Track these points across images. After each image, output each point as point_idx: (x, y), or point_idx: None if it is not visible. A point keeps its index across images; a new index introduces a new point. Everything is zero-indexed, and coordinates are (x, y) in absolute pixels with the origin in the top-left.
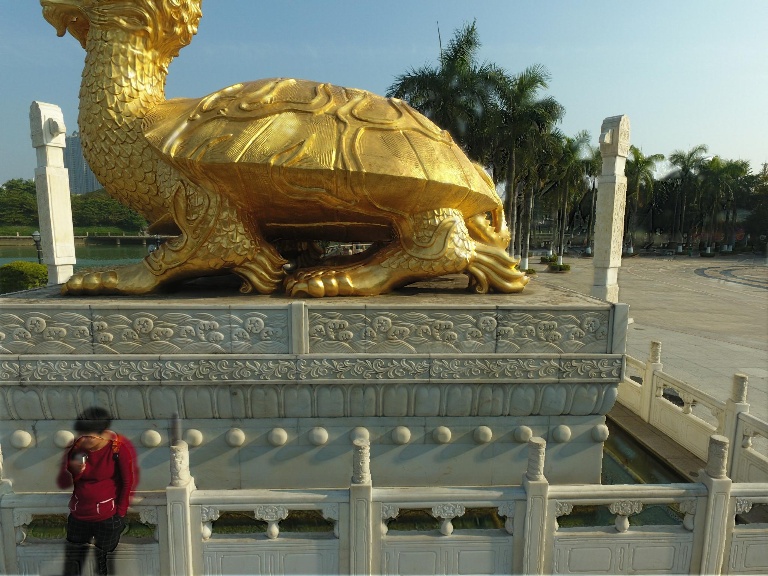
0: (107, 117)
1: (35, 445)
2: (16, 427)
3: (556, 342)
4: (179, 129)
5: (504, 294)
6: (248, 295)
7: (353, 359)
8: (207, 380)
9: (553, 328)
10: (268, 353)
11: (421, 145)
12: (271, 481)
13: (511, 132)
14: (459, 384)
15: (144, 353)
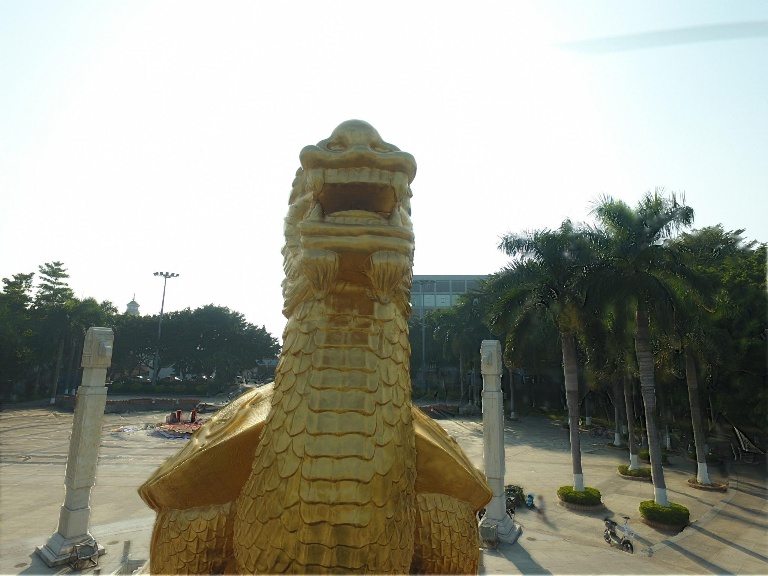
0: None
1: None
2: None
3: None
4: None
5: None
6: None
7: None
8: None
9: None
10: None
11: None
12: None
13: None
14: None
15: None
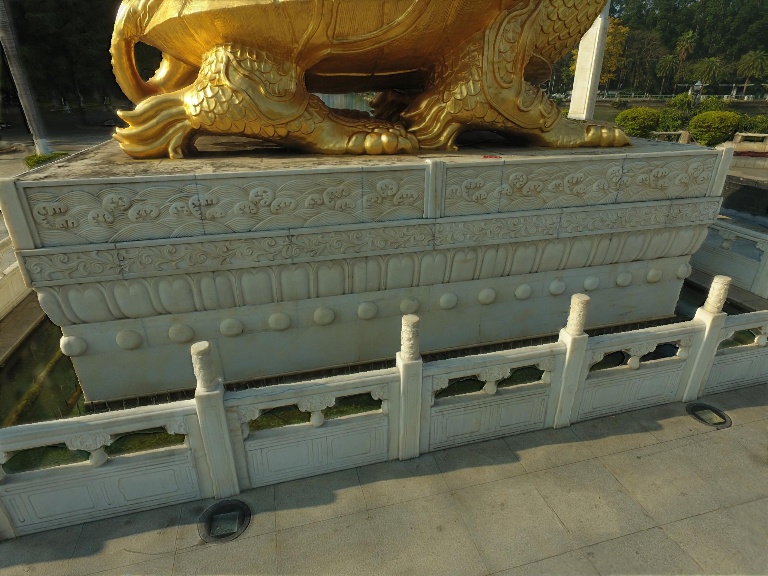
0: None
1: None
2: None
3: None
4: None
5: None
6: None
7: None
8: None
9: None
10: None
11: None
12: None
13: None
14: None
15: None
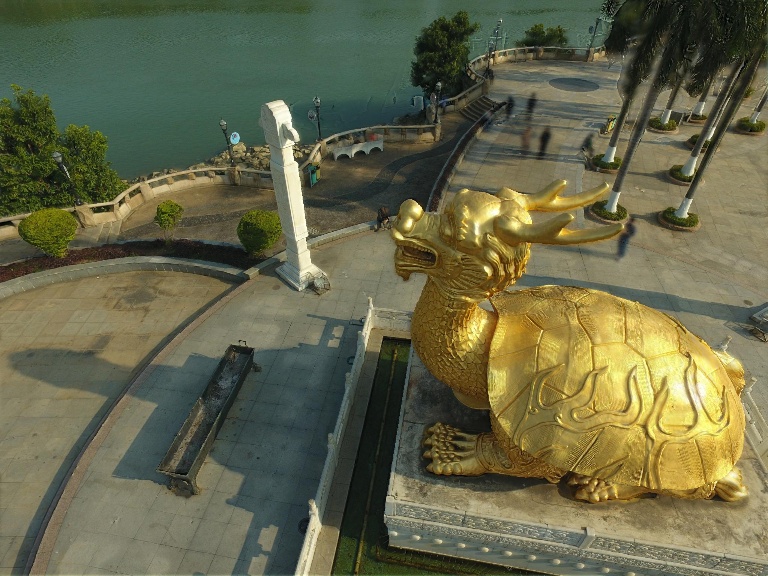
0: (445, 352)
1: (421, 539)
2: (413, 533)
3: (756, 573)
4: (524, 422)
5: (725, 502)
6: (542, 482)
7: (616, 557)
8: (525, 546)
9: (759, 569)
10: (563, 543)
11: (707, 450)
12: (544, 570)
13: (767, 32)
14: (679, 574)
15: (491, 531)
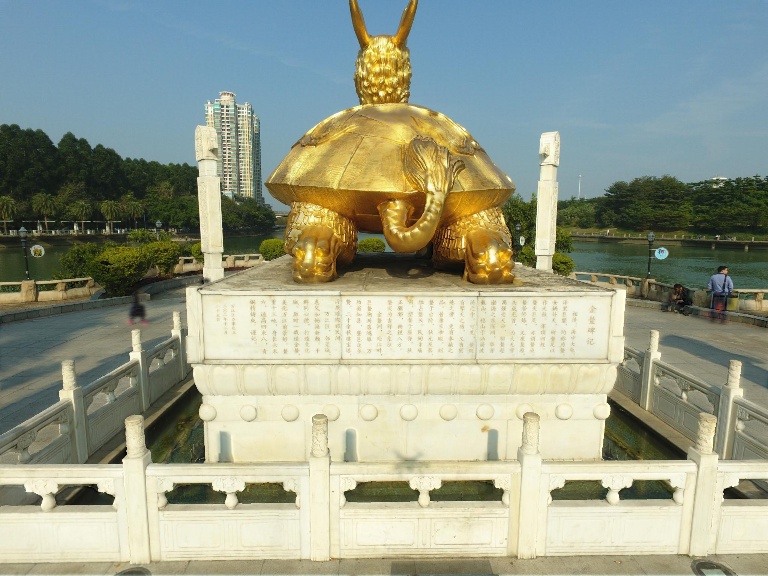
0: None
1: None
2: None
3: None
4: None
5: None
6: None
7: None
8: None
9: None
10: None
11: None
12: None
13: None
14: None
15: None
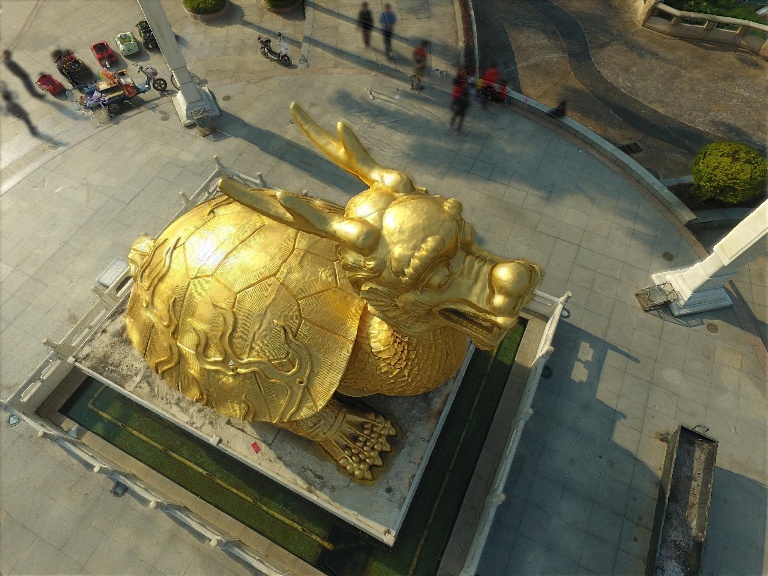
0: None
1: None
2: None
3: None
4: None
5: None
6: None
7: None
8: None
9: None
10: None
11: None
12: None
13: None
14: None
15: None
